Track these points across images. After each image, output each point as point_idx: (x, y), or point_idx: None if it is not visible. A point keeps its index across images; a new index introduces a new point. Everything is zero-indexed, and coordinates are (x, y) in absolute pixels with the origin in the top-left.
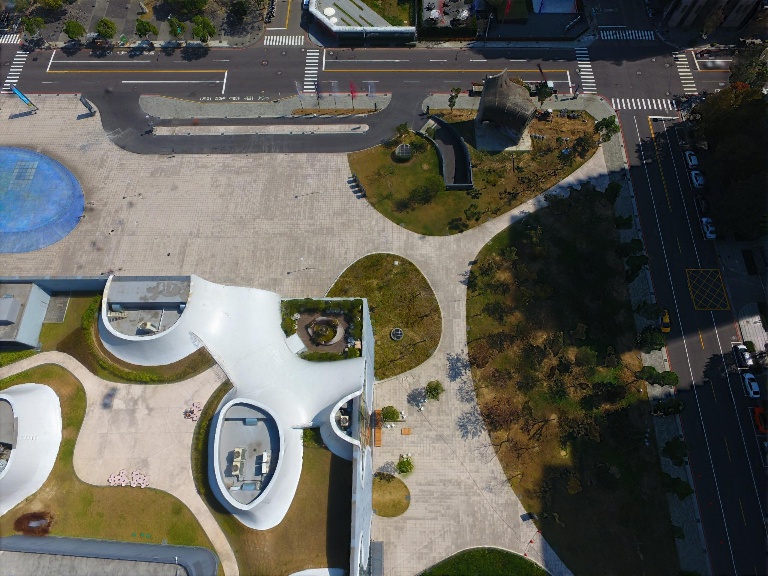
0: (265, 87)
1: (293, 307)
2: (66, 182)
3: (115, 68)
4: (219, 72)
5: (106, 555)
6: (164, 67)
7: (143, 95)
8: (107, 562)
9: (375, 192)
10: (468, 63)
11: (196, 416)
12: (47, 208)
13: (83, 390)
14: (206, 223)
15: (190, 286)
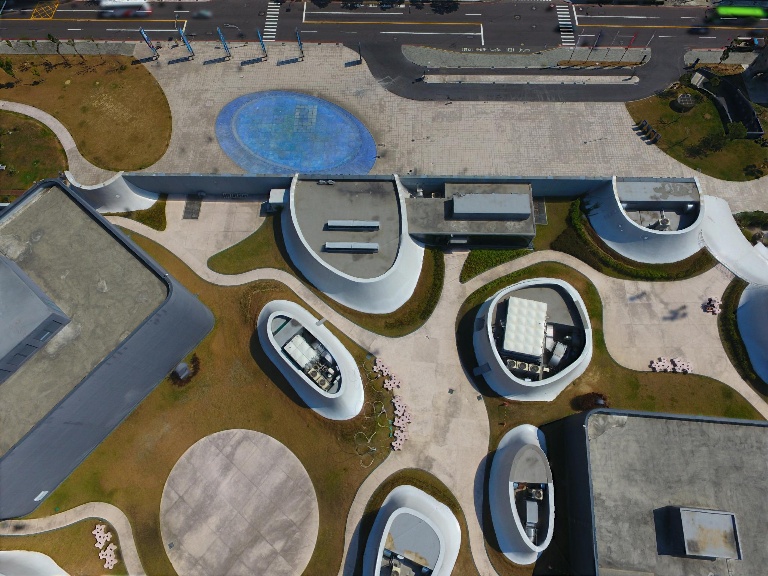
0: (523, 40)
1: (746, 219)
2: (350, 125)
3: (370, 19)
4: (474, 25)
5: (738, 420)
6: (418, 19)
7: (404, 45)
8: (735, 427)
9: (664, 139)
10: (719, 21)
11: (718, 309)
12: (338, 149)
13: (593, 285)
14: (502, 165)
15: (697, 187)
